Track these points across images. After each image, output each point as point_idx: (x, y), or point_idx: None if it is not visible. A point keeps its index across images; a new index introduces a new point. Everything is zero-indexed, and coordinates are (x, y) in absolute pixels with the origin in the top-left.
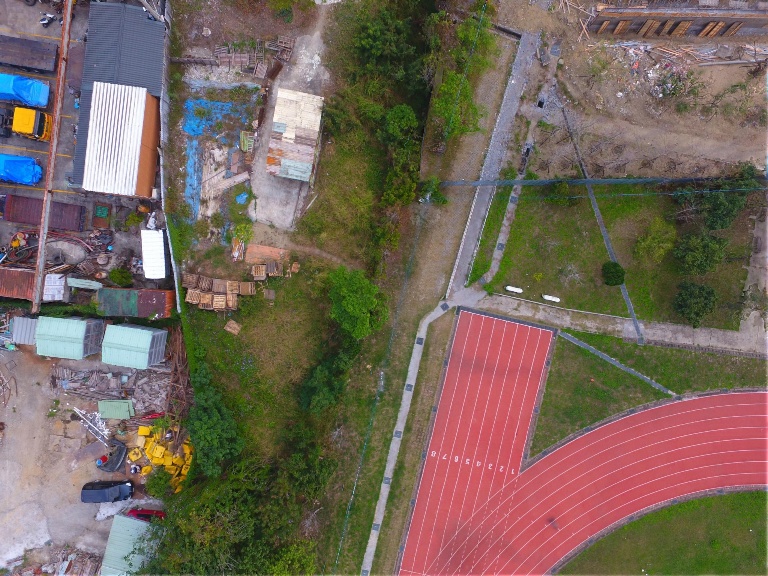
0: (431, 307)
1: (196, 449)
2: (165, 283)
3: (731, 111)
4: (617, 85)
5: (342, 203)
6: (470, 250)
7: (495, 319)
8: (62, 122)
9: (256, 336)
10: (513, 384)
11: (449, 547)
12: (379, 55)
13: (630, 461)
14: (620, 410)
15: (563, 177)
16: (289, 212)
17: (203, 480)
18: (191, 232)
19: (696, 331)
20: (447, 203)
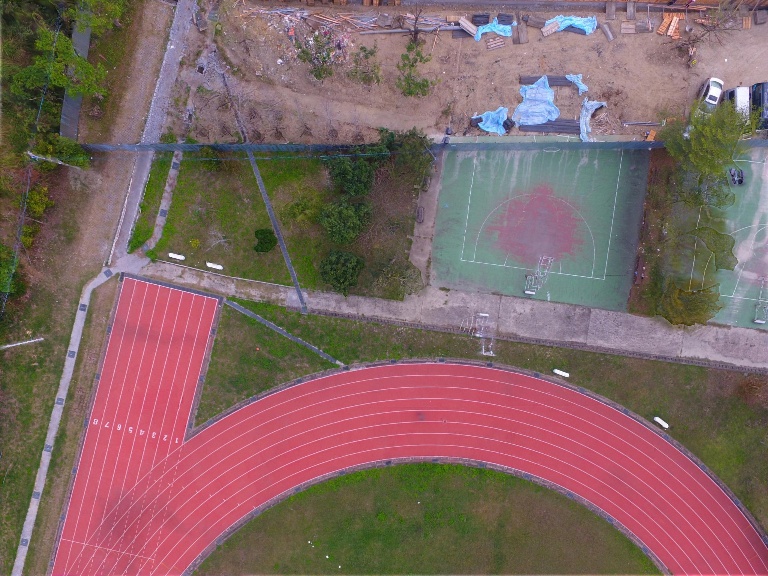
0: (94, 273)
1: None
2: None
3: (394, 80)
4: (276, 52)
5: None
6: (133, 216)
7: (159, 286)
8: None
9: None
10: (178, 352)
11: (111, 516)
12: (3, 14)
13: (297, 431)
14: (287, 380)
15: (221, 143)
16: None
17: None
18: None
19: (360, 301)
20: (108, 168)
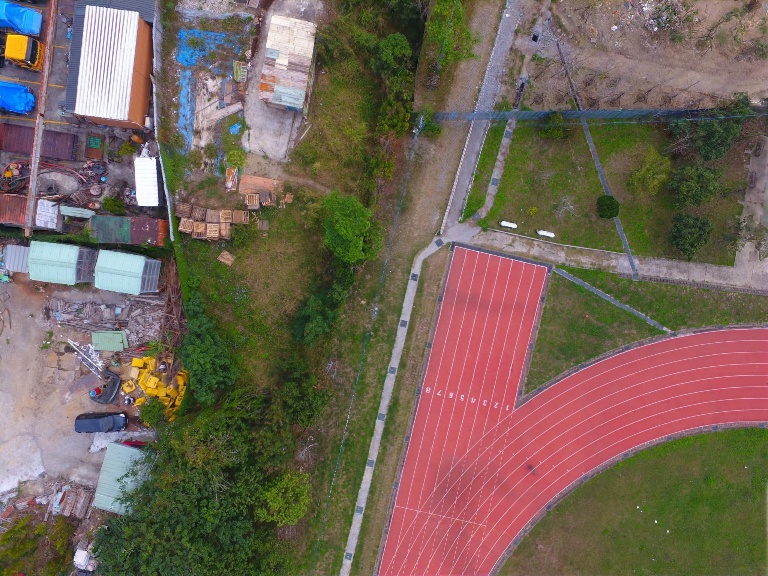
0: (425, 243)
1: (189, 374)
2: (158, 214)
3: (726, 45)
4: (612, 18)
5: (336, 133)
6: (464, 185)
7: (490, 255)
8: (55, 52)
9: (250, 267)
10: (508, 320)
11: (444, 484)
12: None
13: (625, 398)
14: (615, 346)
15: None
16: (283, 143)
17: (197, 410)
18: (184, 163)
19: (691, 266)
20: (441, 138)
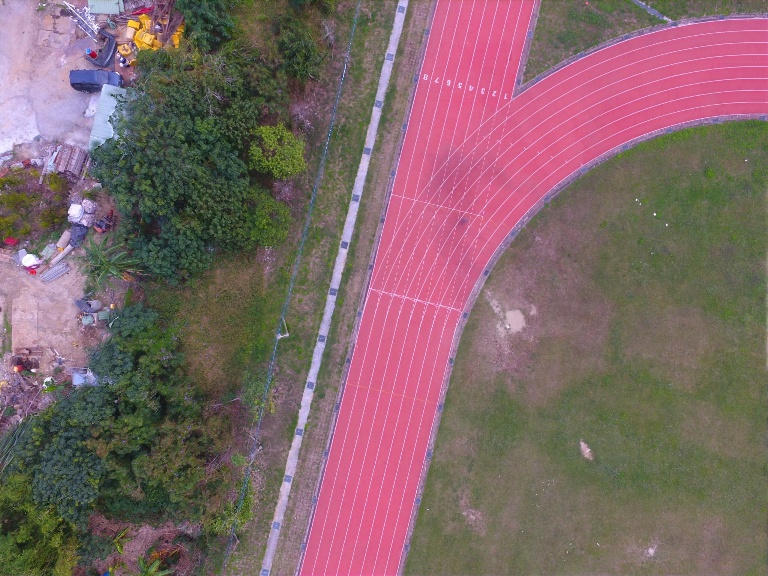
0: None
1: None
2: None
3: None
4: None
5: None
6: None
7: None
8: None
9: None
10: (506, 7)
11: (441, 173)
12: None
13: (624, 88)
14: (615, 35)
15: None
16: None
17: None
18: None
19: None
20: None
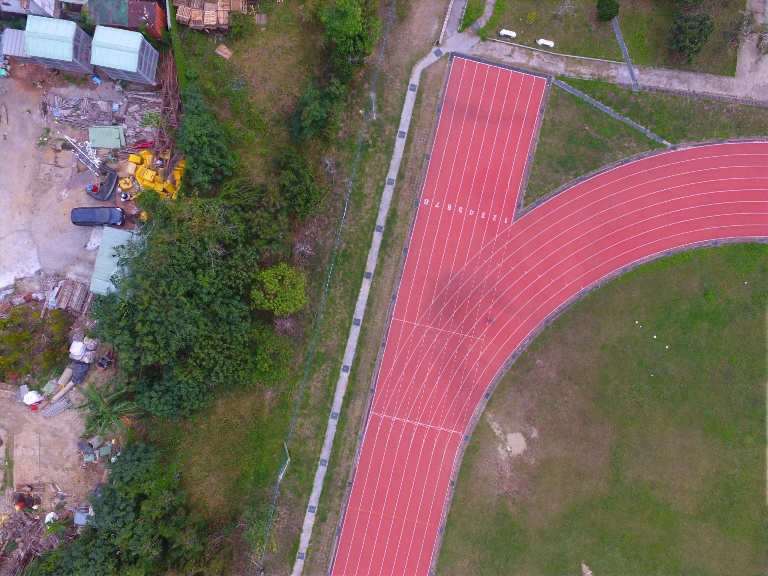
0: (424, 53)
1: (186, 148)
2: None
3: None
4: None
5: None
6: None
7: (489, 66)
8: None
9: (247, 62)
10: (507, 132)
11: (441, 297)
12: None
13: (624, 211)
14: (614, 159)
15: None
16: None
17: None
18: None
19: (691, 77)
20: None
